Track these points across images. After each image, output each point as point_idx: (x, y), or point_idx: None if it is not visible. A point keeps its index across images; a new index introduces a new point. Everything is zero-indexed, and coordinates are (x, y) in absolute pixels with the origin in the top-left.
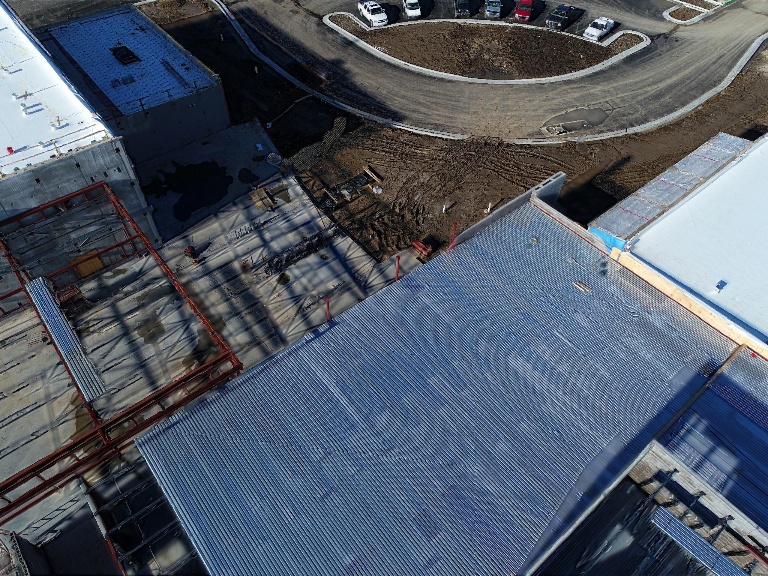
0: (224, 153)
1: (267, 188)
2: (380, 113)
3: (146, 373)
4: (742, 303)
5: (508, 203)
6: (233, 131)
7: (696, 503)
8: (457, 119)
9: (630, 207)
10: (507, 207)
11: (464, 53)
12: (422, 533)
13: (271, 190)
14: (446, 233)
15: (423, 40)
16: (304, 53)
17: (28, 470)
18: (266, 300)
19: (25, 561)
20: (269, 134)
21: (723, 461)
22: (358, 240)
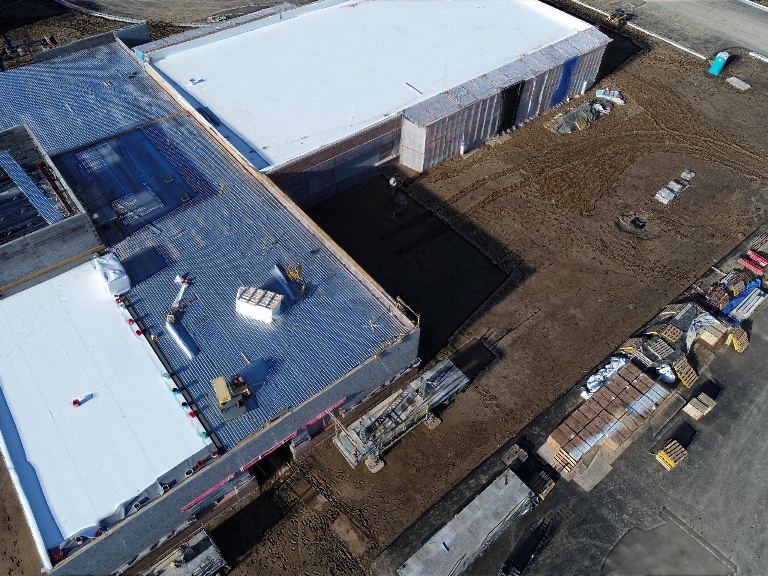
0: None
1: None
2: (89, 6)
3: None
4: (205, 90)
5: None
6: None
7: (74, 174)
8: (147, 11)
9: (168, 39)
10: (87, 40)
11: None
12: None
13: None
14: None
15: None
16: None
17: None
18: None
19: None
20: None
21: (112, 159)
22: None
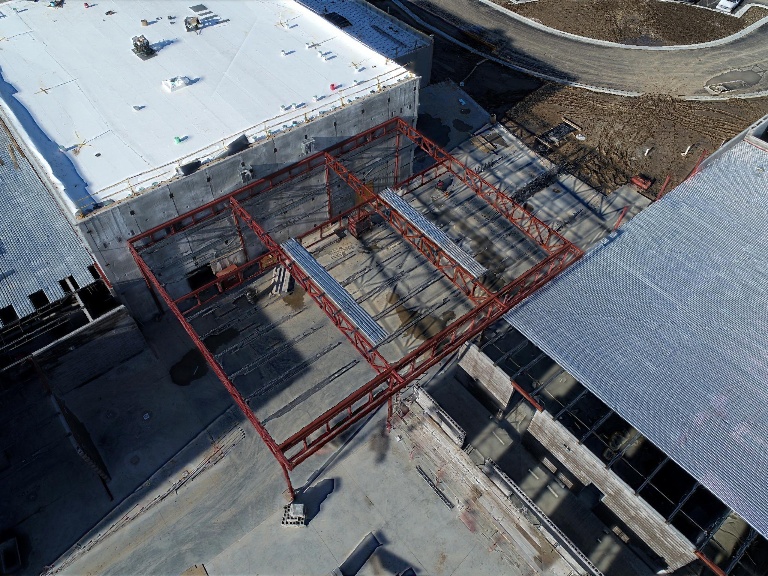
0: (433, 107)
1: (483, 135)
2: (555, 74)
3: (441, 280)
4: None
5: (733, 139)
6: (433, 89)
7: None
8: (626, 79)
9: None
10: (732, 142)
11: (612, 23)
12: (762, 380)
13: (487, 137)
14: (654, 172)
15: (571, 12)
16: (465, 23)
17: (455, 324)
18: (520, 224)
19: (437, 403)
20: (465, 91)
21: None
22: (579, 178)
